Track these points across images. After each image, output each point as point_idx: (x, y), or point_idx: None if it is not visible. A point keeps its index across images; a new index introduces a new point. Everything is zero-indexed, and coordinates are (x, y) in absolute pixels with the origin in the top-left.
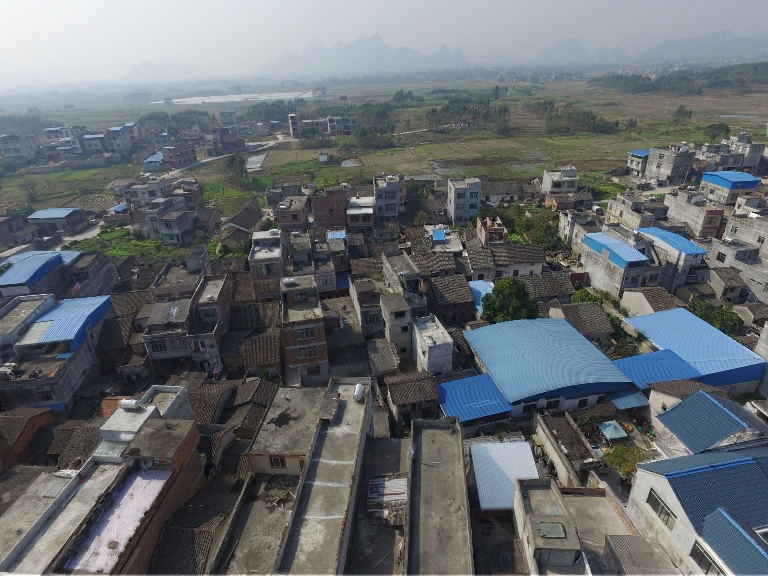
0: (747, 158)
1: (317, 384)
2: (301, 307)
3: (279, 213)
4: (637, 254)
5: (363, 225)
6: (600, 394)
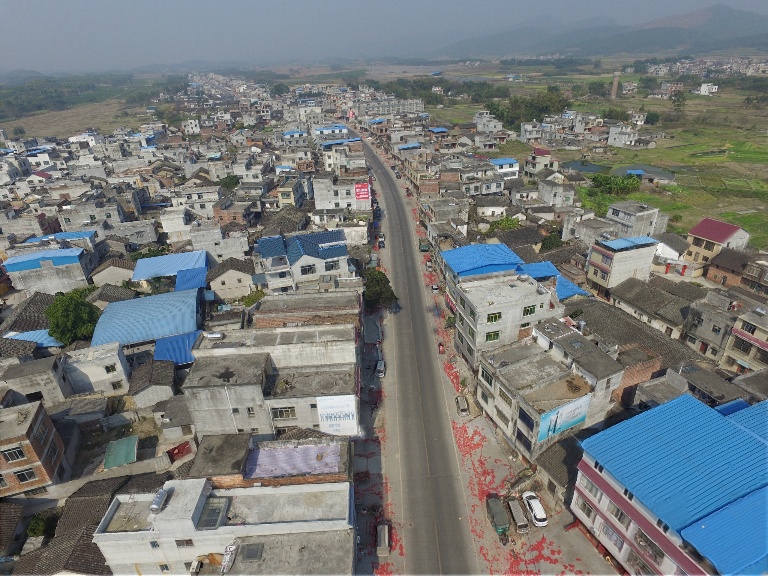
0: None
1: None
2: None
3: None
4: (72, 250)
5: None
6: (199, 303)
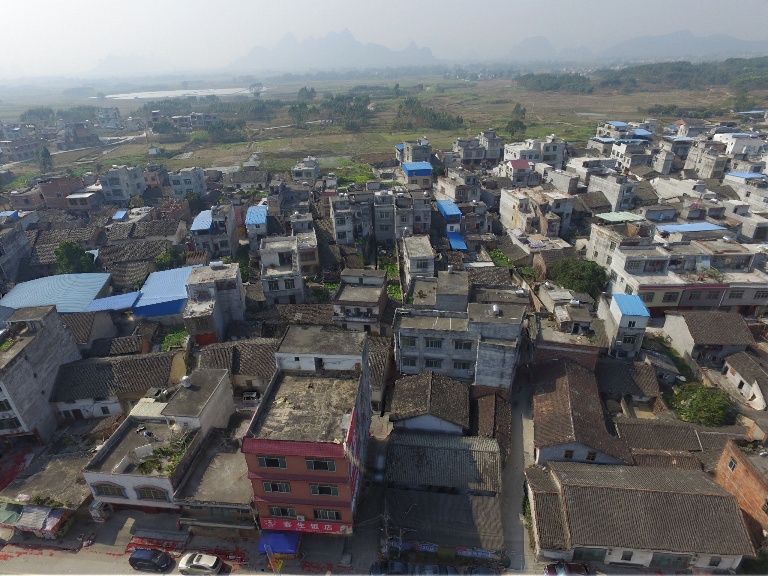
0: (488, 151)
1: None
2: None
3: (11, 198)
4: (206, 225)
5: (82, 208)
6: None
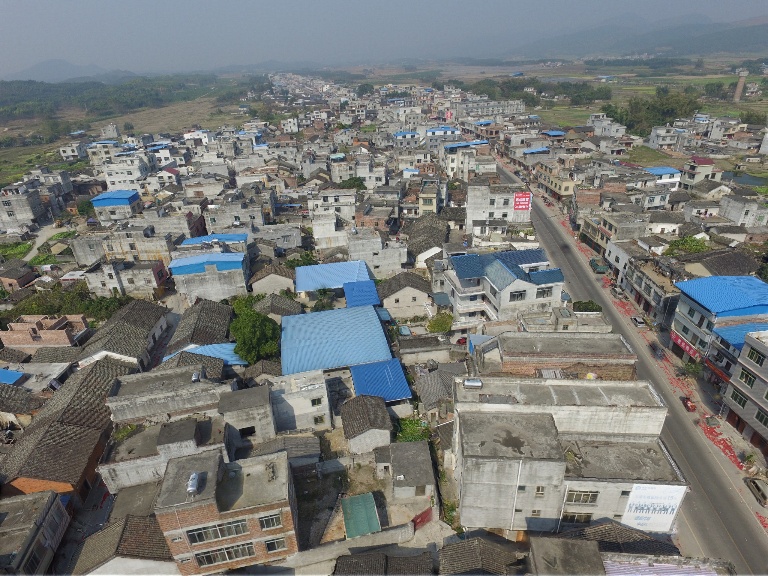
0: (64, 185)
1: (301, 544)
2: (231, 492)
3: None
4: (234, 254)
5: None
6: None
